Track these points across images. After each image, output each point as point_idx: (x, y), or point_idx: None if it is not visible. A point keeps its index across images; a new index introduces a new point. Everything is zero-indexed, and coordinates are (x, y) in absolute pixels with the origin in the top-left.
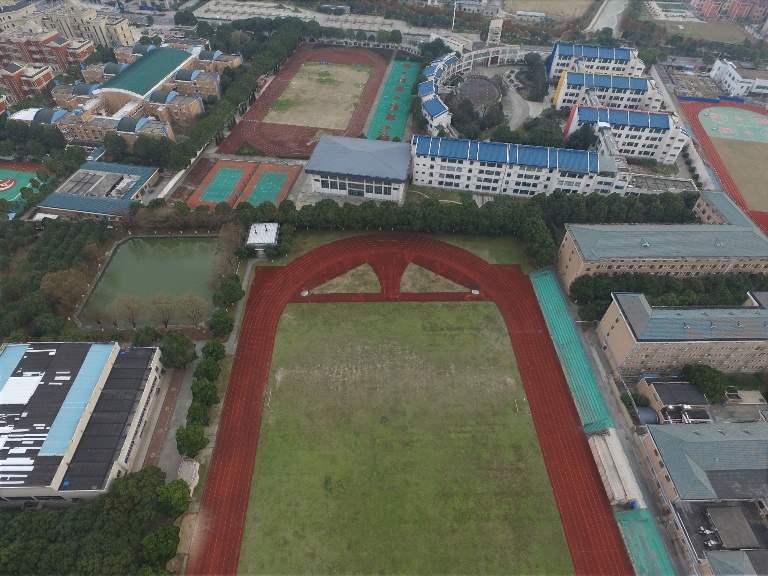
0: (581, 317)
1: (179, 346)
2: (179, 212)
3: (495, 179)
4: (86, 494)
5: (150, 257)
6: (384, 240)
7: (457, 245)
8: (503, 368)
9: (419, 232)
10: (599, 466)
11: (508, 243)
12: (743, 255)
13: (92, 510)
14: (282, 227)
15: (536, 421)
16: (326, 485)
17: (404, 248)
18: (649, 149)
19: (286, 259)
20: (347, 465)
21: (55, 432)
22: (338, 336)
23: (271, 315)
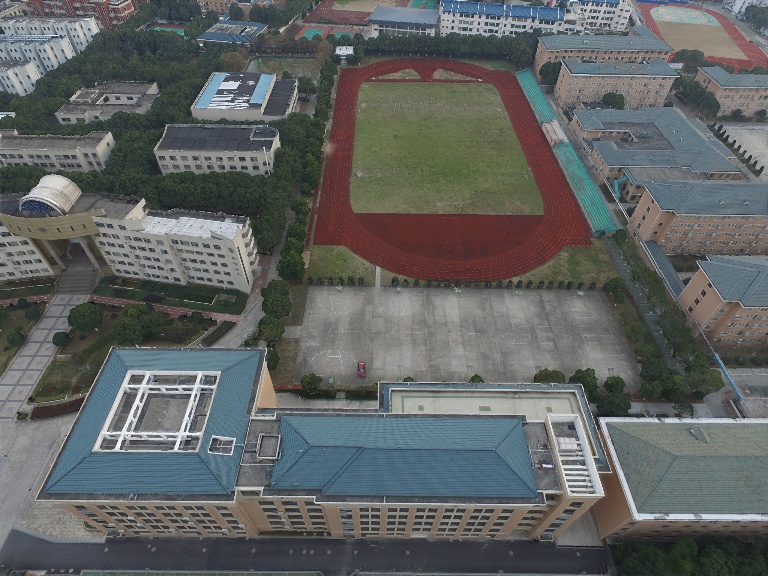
0: (545, 84)
1: (308, 80)
2: (290, 39)
3: (496, 30)
4: (276, 119)
5: (269, 71)
6: (421, 60)
7: (469, 62)
8: (495, 106)
9: (444, 57)
10: (546, 134)
11: (503, 62)
12: (647, 49)
13: (281, 121)
14: (357, 46)
15: (513, 122)
16: (395, 137)
17: (435, 63)
18: (607, 21)
19: (359, 66)
20: (406, 132)
21: (255, 97)
22: (396, 93)
23: (354, 85)
